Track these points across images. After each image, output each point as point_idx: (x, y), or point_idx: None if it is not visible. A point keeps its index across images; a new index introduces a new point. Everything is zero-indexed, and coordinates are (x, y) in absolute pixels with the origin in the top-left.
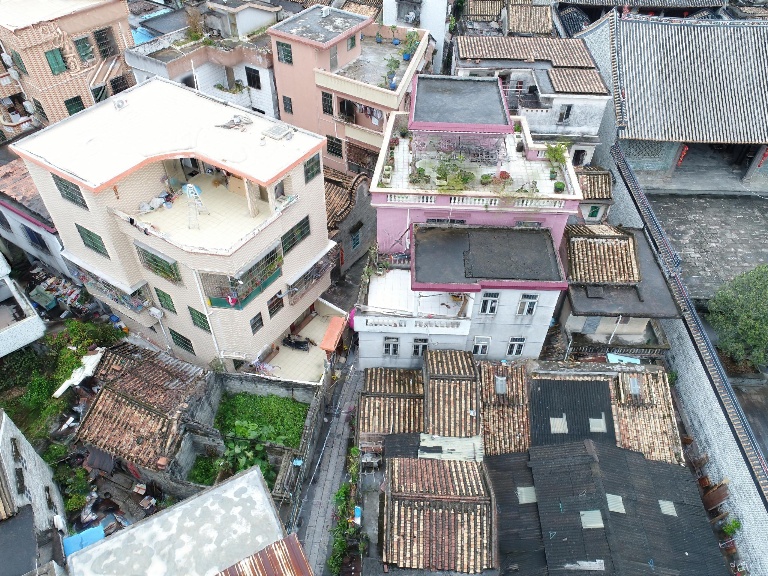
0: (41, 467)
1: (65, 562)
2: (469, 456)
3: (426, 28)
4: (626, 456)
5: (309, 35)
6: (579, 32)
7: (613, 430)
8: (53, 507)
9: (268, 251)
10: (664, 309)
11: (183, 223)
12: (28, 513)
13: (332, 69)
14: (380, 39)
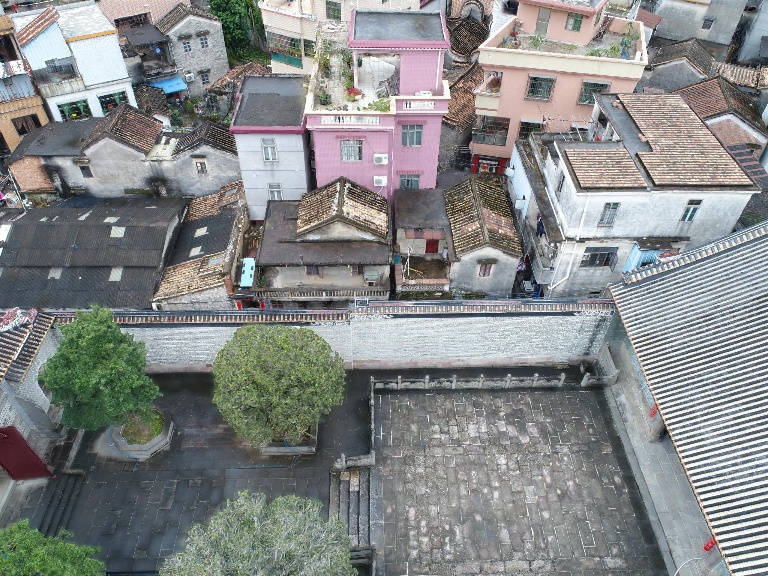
0: (221, 66)
1: (162, 73)
2: (159, 154)
3: None
4: (156, 250)
5: None
6: None
7: (189, 260)
8: (205, 79)
9: (289, 36)
10: (267, 254)
11: (308, 6)
12: (165, 38)
13: (538, 32)
14: (624, 50)
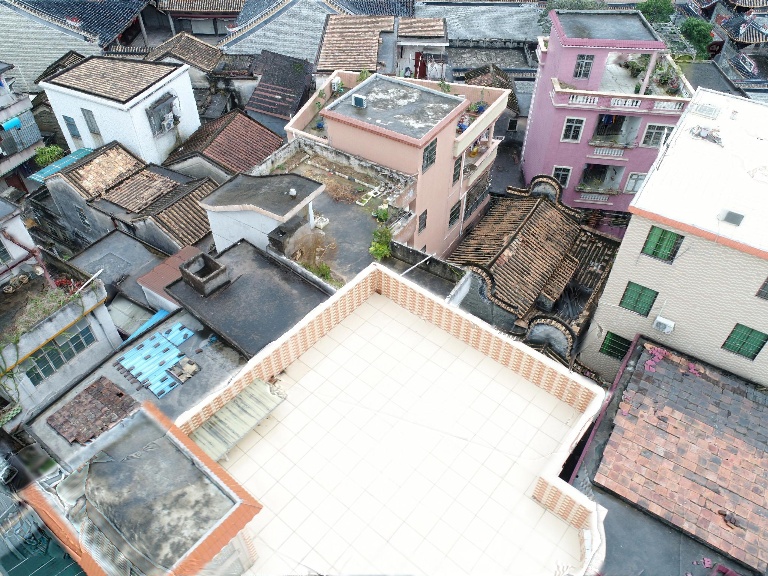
0: None
1: None
2: None
3: (182, 122)
4: None
5: (433, 113)
6: (232, 37)
7: None
8: None
9: None
10: None
11: None
12: None
13: None
14: None
